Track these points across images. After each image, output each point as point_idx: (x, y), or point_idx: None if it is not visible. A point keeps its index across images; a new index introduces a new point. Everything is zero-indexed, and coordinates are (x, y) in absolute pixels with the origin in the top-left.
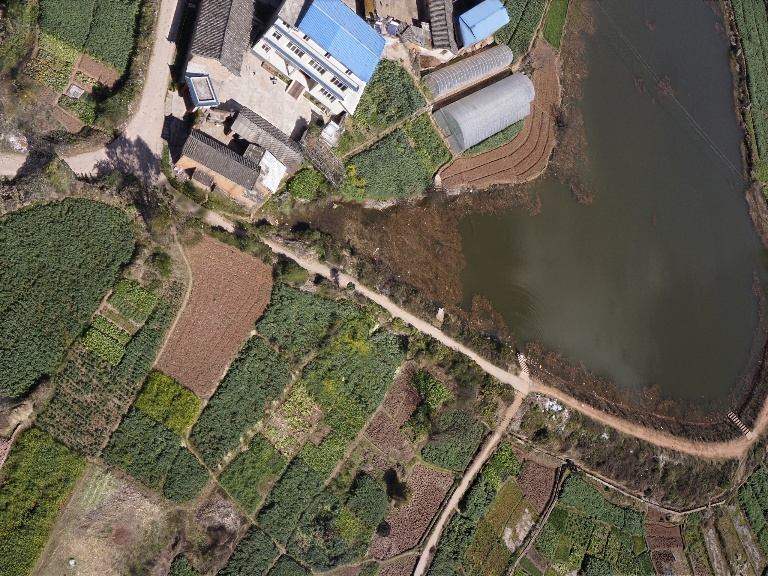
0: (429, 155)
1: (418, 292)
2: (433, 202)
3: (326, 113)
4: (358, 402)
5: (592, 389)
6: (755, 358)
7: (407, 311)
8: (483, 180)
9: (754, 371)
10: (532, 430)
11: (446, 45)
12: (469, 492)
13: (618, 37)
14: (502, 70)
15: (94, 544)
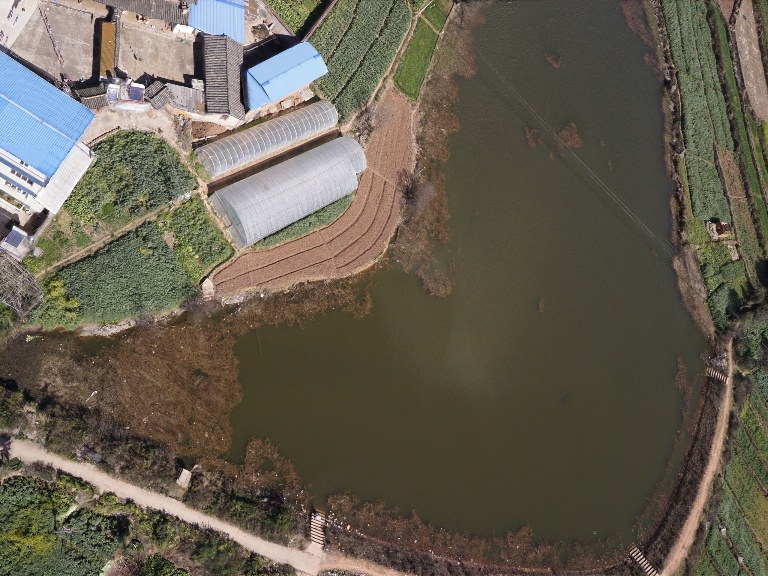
0: (196, 254)
1: (152, 449)
2: (198, 317)
3: (25, 211)
4: None
5: (428, 547)
6: (674, 470)
7: (126, 481)
8: (282, 279)
9: (672, 488)
10: None
11: (223, 109)
12: None
13: (499, 81)
14: (325, 132)
15: None
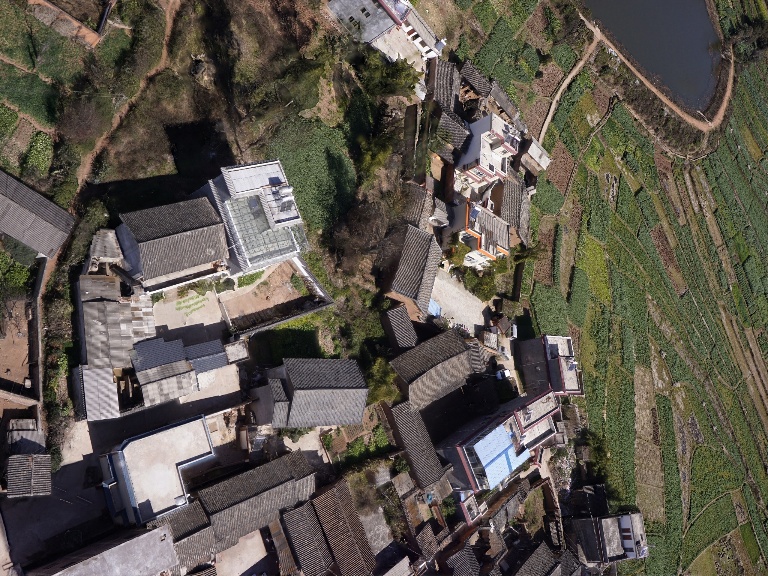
0: None
1: None
2: None
3: None
4: (524, 6)
5: None
6: (711, 90)
7: None
8: None
9: (711, 97)
10: (600, 65)
11: None
12: (571, 84)
13: None
14: None
15: (434, 8)
